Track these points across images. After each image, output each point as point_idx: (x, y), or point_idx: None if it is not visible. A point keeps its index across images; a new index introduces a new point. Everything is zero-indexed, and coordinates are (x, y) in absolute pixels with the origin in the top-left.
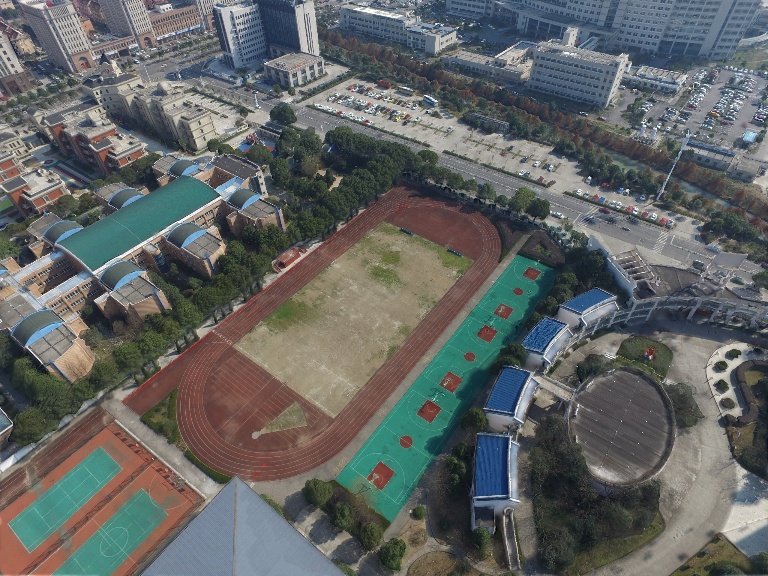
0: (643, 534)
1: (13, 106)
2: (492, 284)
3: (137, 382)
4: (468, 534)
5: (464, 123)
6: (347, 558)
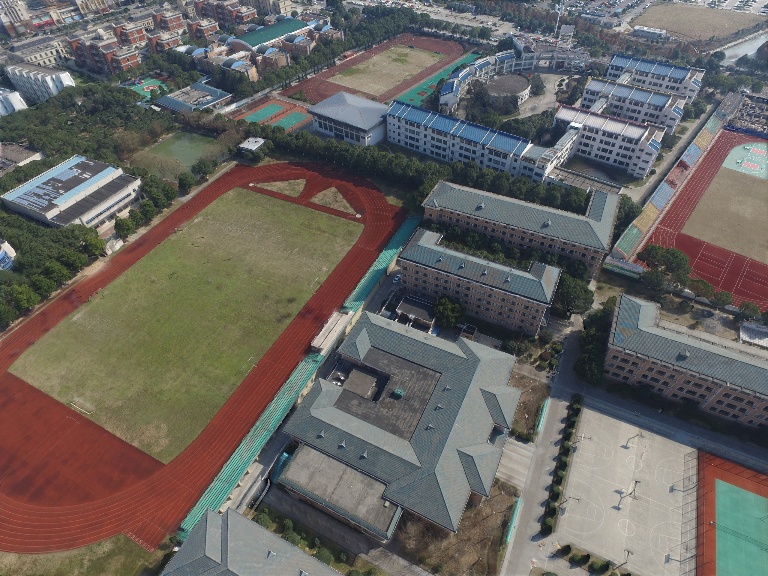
0: (510, 115)
1: (156, 3)
2: (457, 62)
3: (282, 88)
4: None
5: (448, 9)
6: None
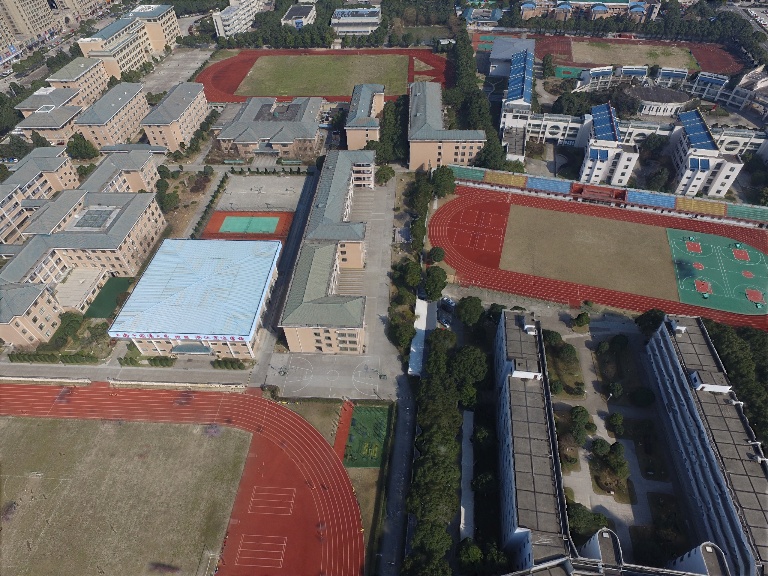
0: None
1: None
2: None
3: (536, 33)
4: None
5: None
6: (537, 73)
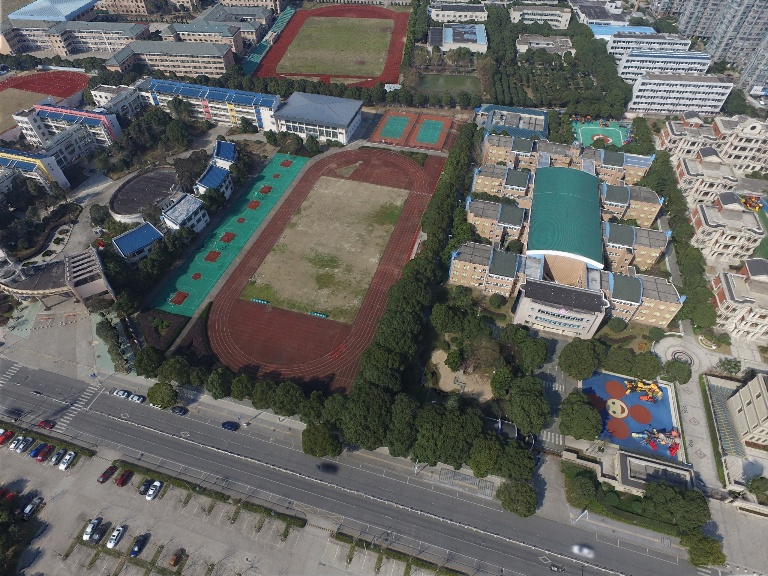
0: None
1: None
2: (221, 278)
3: None
4: (239, 152)
5: None
6: None
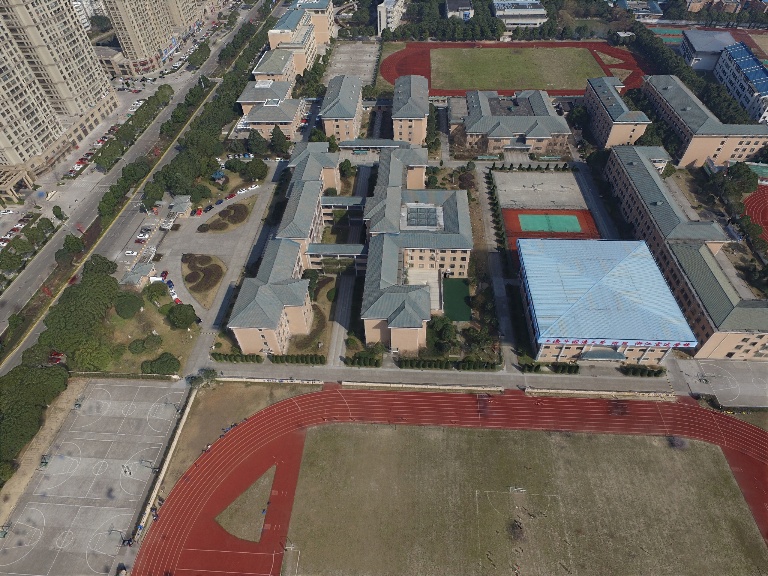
0: None
1: None
2: None
3: (705, 25)
4: None
5: None
6: None
